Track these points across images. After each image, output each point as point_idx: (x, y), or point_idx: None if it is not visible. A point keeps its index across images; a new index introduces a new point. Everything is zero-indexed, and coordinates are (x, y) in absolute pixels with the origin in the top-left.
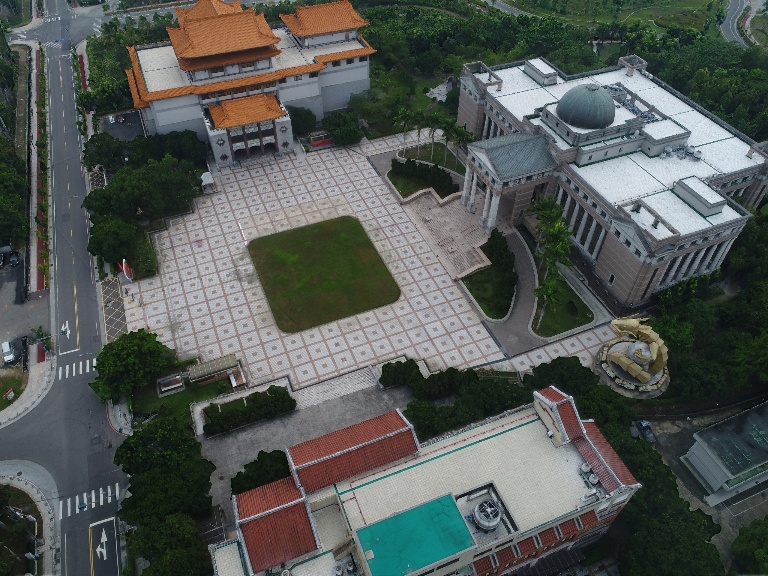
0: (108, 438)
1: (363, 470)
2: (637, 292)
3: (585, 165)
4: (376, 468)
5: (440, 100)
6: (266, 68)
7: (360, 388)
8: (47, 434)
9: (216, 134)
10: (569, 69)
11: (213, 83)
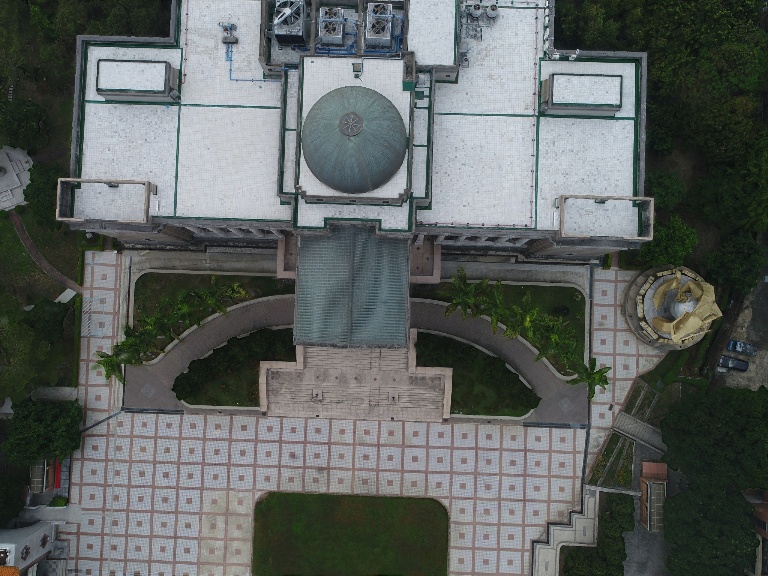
0: None
1: None
2: None
3: None
4: None
5: (16, 210)
6: None
7: None
8: None
9: None
10: None
11: None
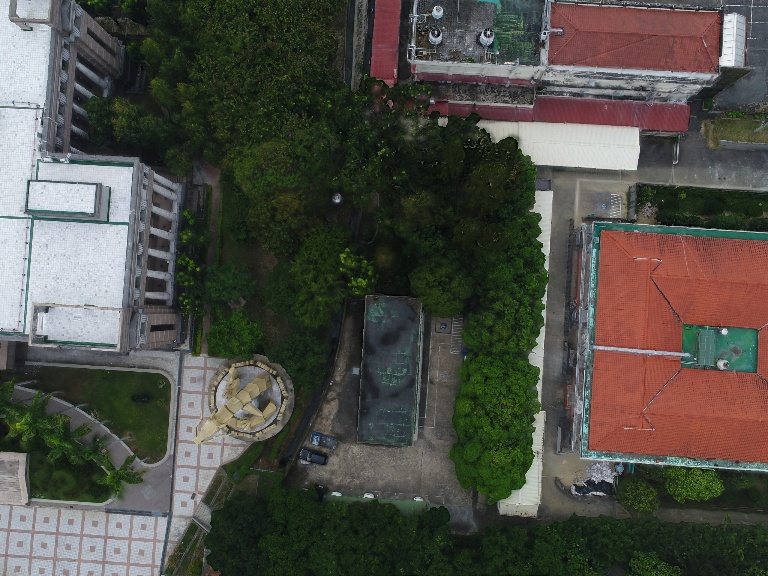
0: None
1: None
2: (165, 341)
3: None
4: None
5: None
6: None
7: None
8: None
9: None
10: None
11: None
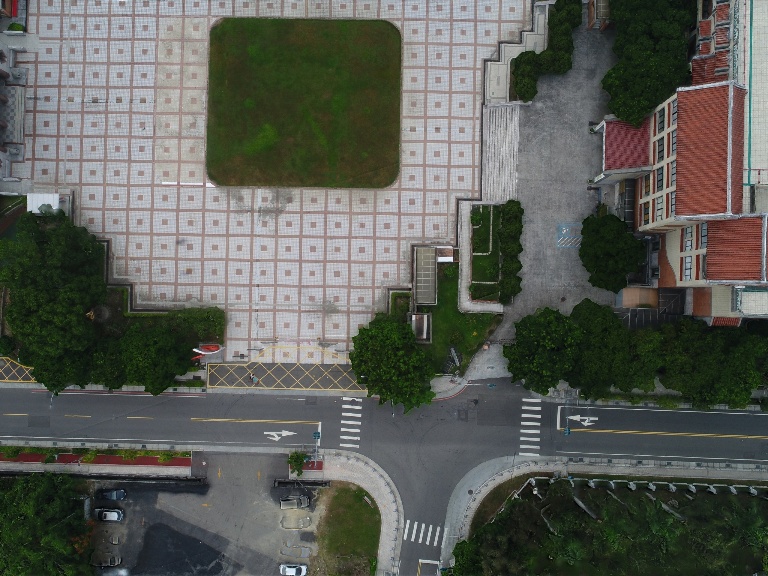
0: (465, 403)
1: (742, 151)
2: None
3: None
4: None
5: None
6: None
7: (516, 127)
8: (432, 464)
9: None
10: None
11: None
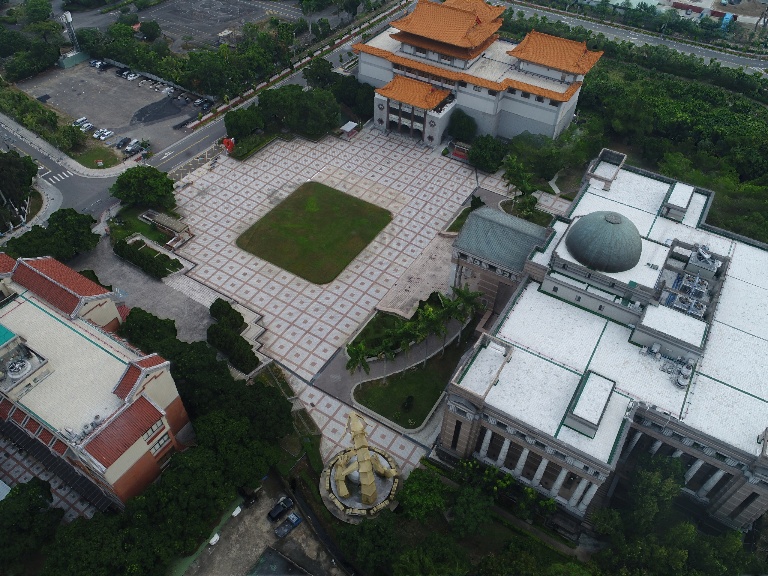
0: (94, 216)
1: (41, 295)
2: None
3: (548, 293)
4: (49, 303)
5: None
6: (460, 68)
7: (205, 304)
8: (84, 193)
9: (379, 98)
10: (759, 230)
11: (405, 58)
